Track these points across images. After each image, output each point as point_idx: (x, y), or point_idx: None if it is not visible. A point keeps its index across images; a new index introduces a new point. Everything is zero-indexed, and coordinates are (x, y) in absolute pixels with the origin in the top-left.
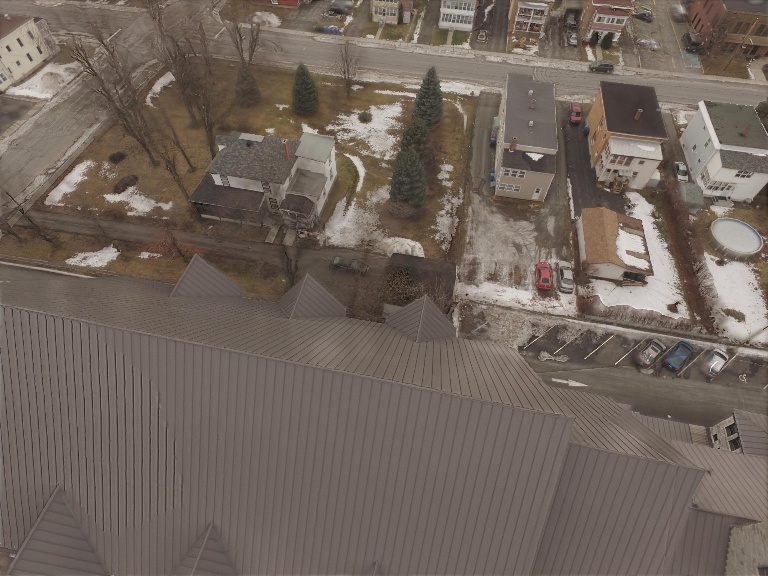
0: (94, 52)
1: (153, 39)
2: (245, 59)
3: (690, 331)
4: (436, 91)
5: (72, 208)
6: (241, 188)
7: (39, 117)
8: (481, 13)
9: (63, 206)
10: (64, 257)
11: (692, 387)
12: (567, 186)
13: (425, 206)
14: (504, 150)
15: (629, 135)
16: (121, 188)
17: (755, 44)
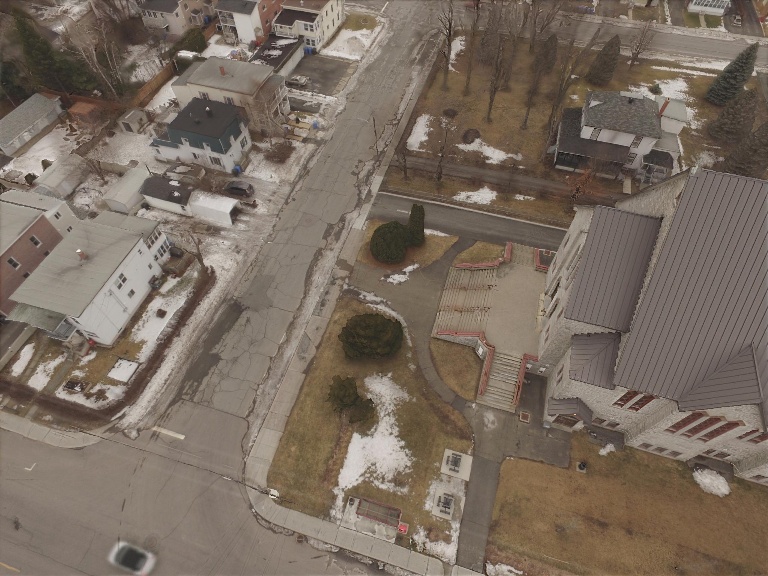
0: (376, 21)
1: (509, 5)
2: (536, 31)
3: None
4: (752, 66)
5: (434, 154)
6: (607, 142)
7: (359, 75)
8: None
9: (425, 152)
10: (450, 194)
11: None
12: None
13: None
14: None
15: None
16: (470, 139)
17: None
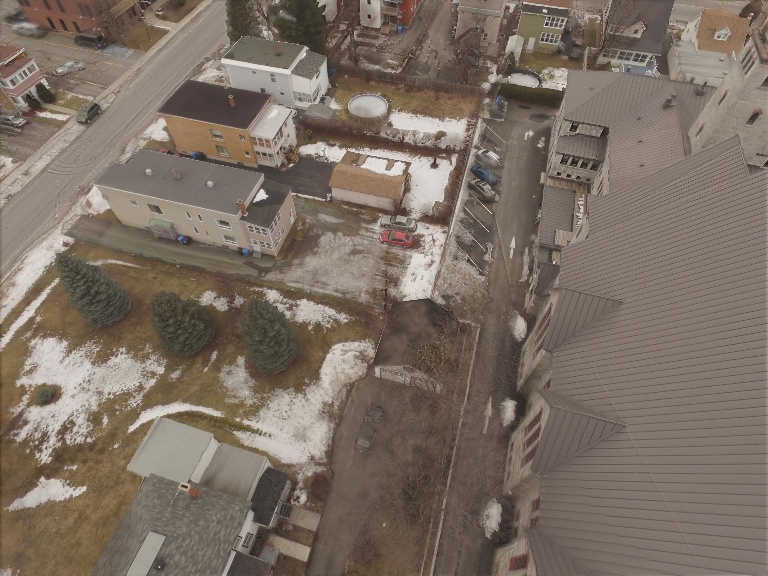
0: None
1: None
2: None
3: None
4: (90, 269)
5: None
6: None
7: None
8: None
9: None
10: None
11: (508, 177)
12: None
13: None
14: (242, 220)
15: (256, 118)
16: None
17: (130, 6)
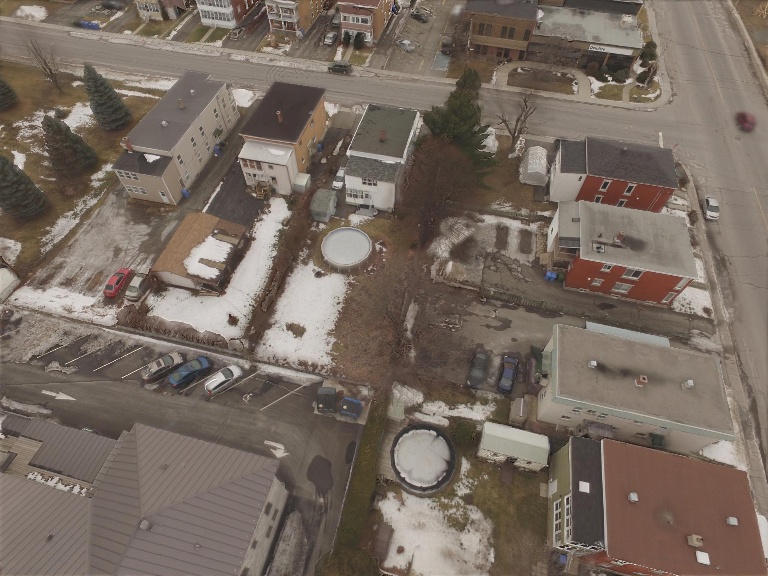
0: None
1: None
2: None
3: (212, 346)
4: (99, 88)
5: None
6: None
7: None
8: (257, 10)
9: None
10: None
11: (185, 405)
12: (214, 190)
13: (55, 206)
14: (123, 151)
15: (260, 138)
16: None
17: (504, 47)
